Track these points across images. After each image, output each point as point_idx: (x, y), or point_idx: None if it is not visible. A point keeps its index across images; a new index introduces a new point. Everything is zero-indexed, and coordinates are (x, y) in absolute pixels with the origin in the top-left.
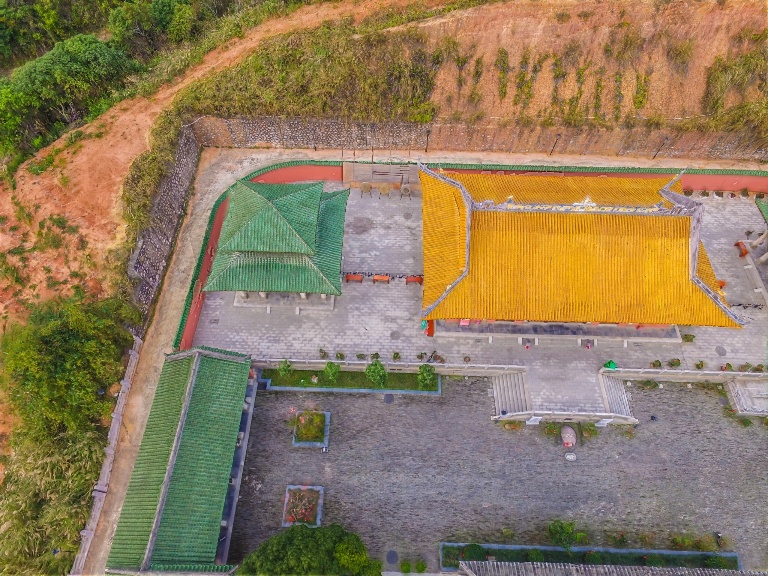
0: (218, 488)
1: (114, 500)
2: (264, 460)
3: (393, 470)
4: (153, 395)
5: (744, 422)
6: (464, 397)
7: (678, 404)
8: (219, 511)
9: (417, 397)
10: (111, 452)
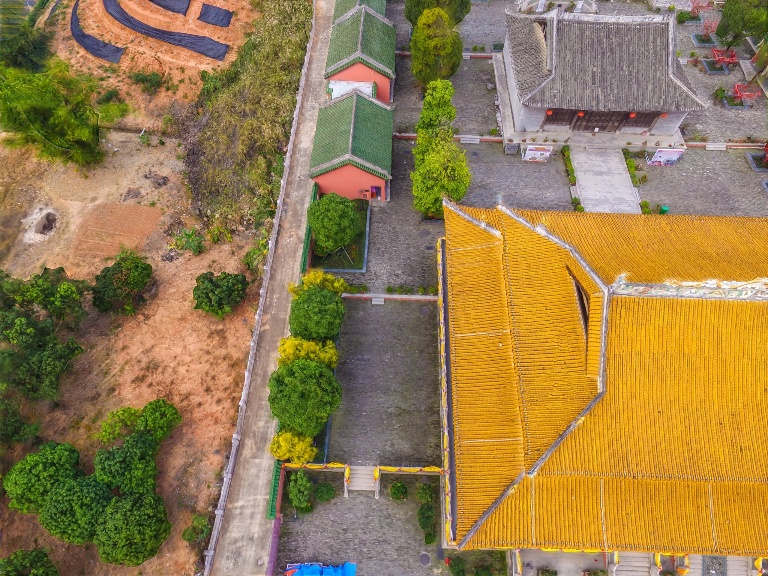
0: (381, 4)
1: (320, 32)
2: (395, 22)
3: (465, 25)
4: (330, 0)
5: (656, 9)
6: (502, 4)
7: (621, 7)
8: (383, 11)
9: (475, 4)
10: (314, 15)
